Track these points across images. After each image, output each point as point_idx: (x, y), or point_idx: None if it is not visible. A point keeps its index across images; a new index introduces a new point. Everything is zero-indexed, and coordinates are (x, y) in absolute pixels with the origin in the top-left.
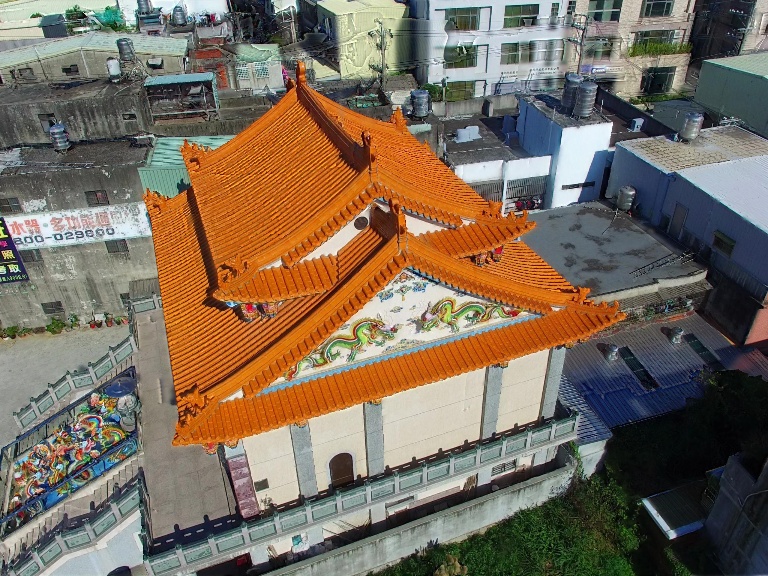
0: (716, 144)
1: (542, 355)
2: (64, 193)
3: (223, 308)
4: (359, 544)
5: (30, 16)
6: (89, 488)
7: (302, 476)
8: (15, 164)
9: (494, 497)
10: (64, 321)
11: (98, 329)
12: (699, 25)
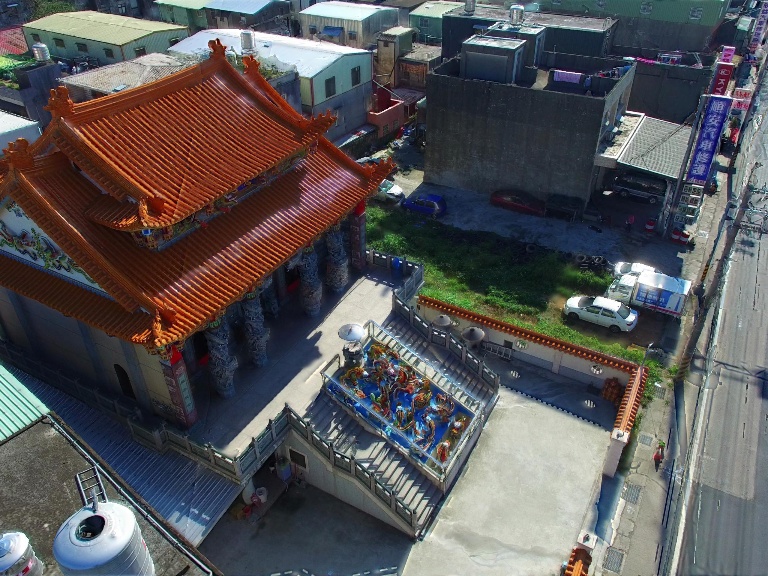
0: None
1: None
2: None
3: (300, 190)
4: None
5: None
6: None
7: None
8: None
9: None
10: None
11: None
12: None
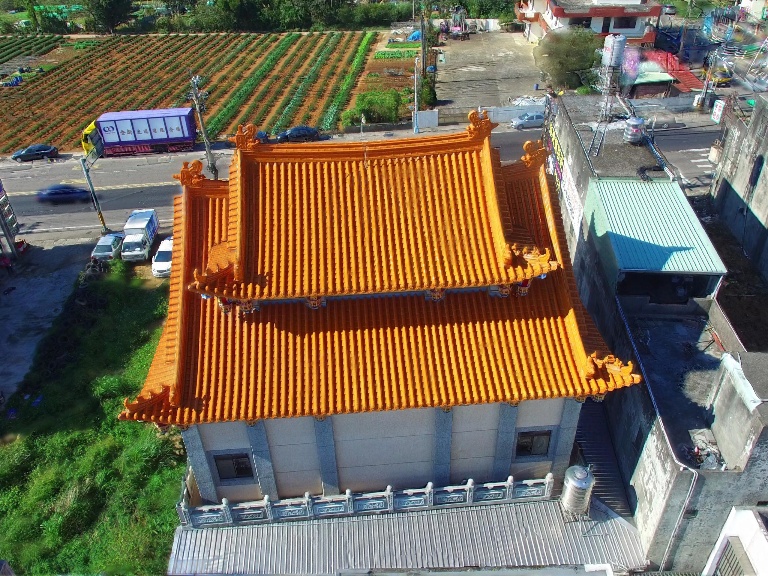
0: None
1: None
2: None
3: None
4: None
5: None
6: None
7: None
8: (600, 129)
9: None
10: None
11: None
12: None
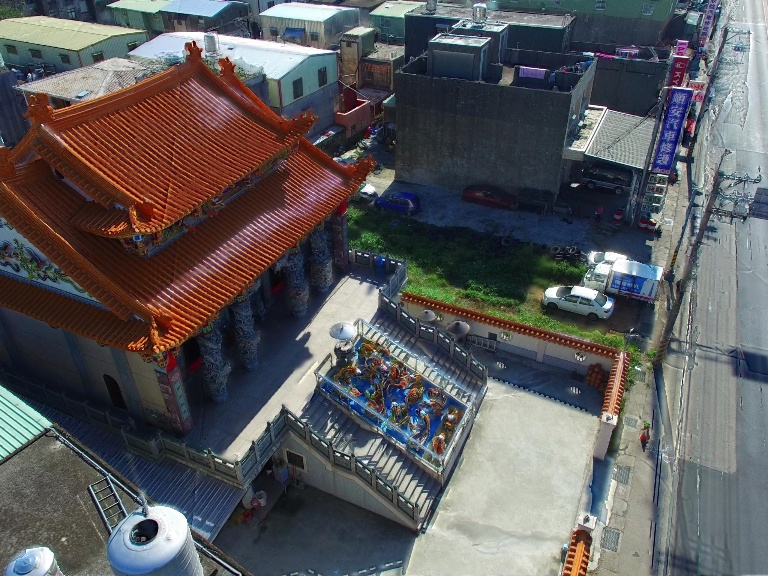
0: None
1: None
2: None
3: (284, 192)
4: None
5: None
6: None
7: None
8: None
9: None
10: None
11: None
12: None
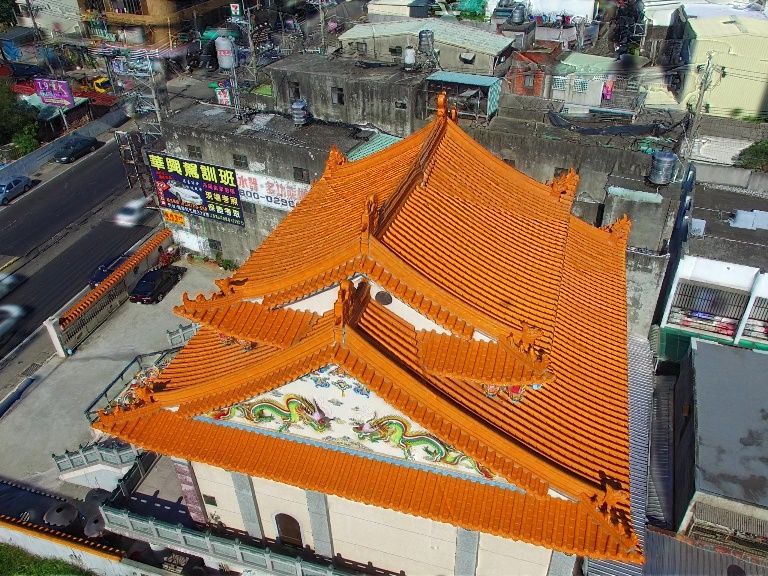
0: None
1: None
2: (279, 163)
3: None
4: None
5: None
6: None
7: (245, 514)
8: (258, 127)
9: None
10: None
11: None
12: None
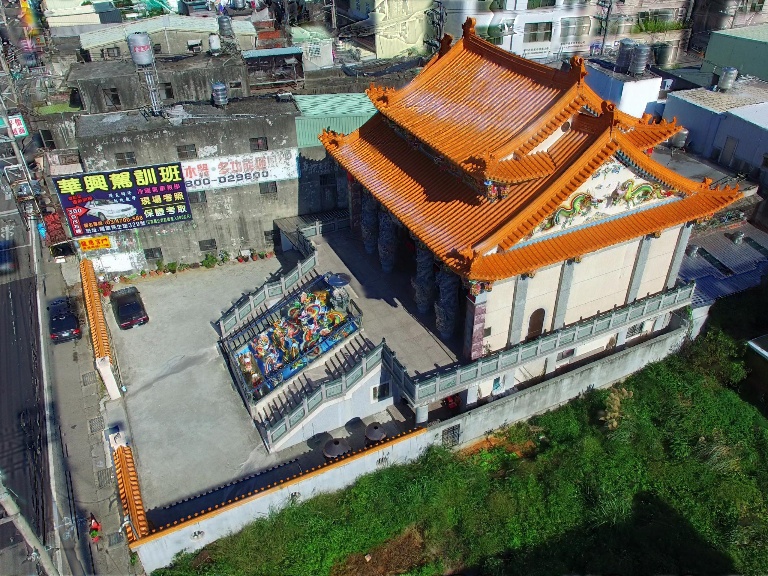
0: (747, 92)
1: (675, 233)
2: (233, 140)
3: (449, 200)
4: (547, 383)
5: (81, 4)
6: (322, 359)
7: (514, 325)
8: (187, 117)
9: (635, 349)
10: (216, 257)
11: (246, 263)
12: (699, 4)
